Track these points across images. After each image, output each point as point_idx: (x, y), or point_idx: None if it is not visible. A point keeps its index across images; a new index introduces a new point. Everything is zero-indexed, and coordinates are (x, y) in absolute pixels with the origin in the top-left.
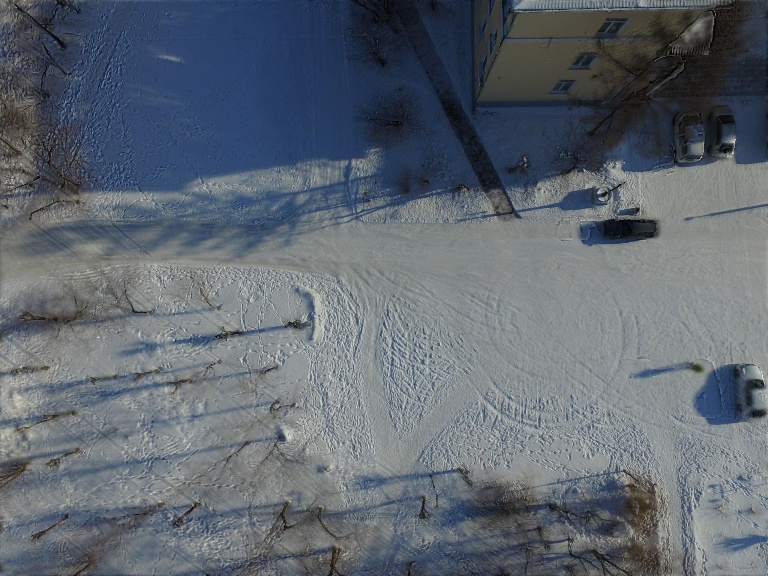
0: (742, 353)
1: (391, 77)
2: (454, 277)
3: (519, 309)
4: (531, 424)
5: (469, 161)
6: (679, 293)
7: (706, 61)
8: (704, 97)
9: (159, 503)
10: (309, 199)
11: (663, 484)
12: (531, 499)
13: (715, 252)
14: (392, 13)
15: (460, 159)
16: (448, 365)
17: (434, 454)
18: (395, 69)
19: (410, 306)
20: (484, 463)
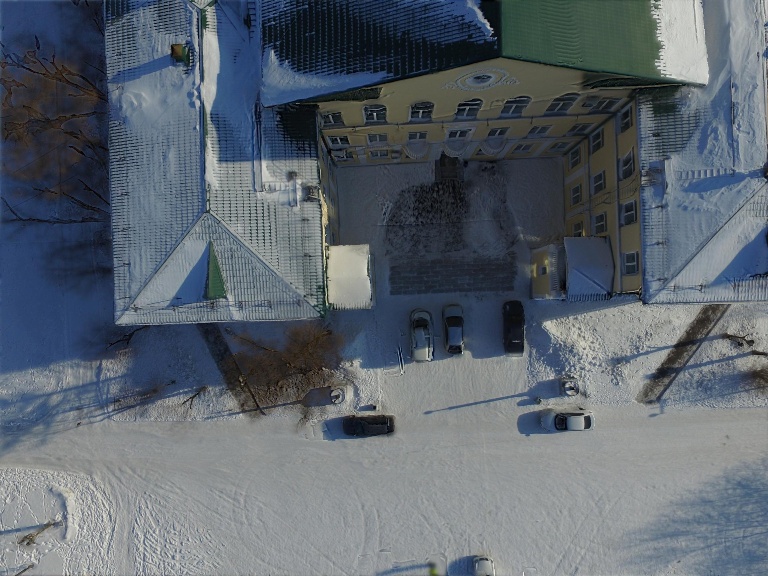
0: (480, 545)
1: None
2: (203, 473)
3: (265, 504)
4: None
5: (214, 360)
6: (419, 486)
7: (435, 263)
8: (439, 294)
9: None
10: (63, 400)
11: None
12: None
13: (454, 445)
14: None
15: (205, 359)
16: (197, 560)
17: None
18: None
19: (161, 503)
20: None
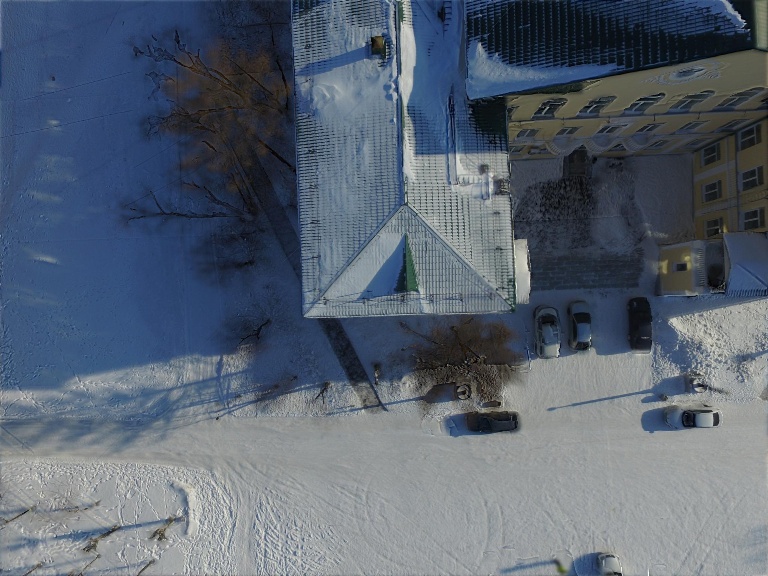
0: (604, 542)
1: (259, 275)
2: (324, 469)
3: (387, 500)
4: None
5: (336, 356)
6: (542, 483)
7: (562, 259)
8: (564, 290)
9: None
10: (183, 395)
11: None
12: None
13: (577, 442)
14: (258, 213)
15: (327, 355)
16: (319, 556)
17: None
18: (262, 268)
19: (282, 498)
20: None
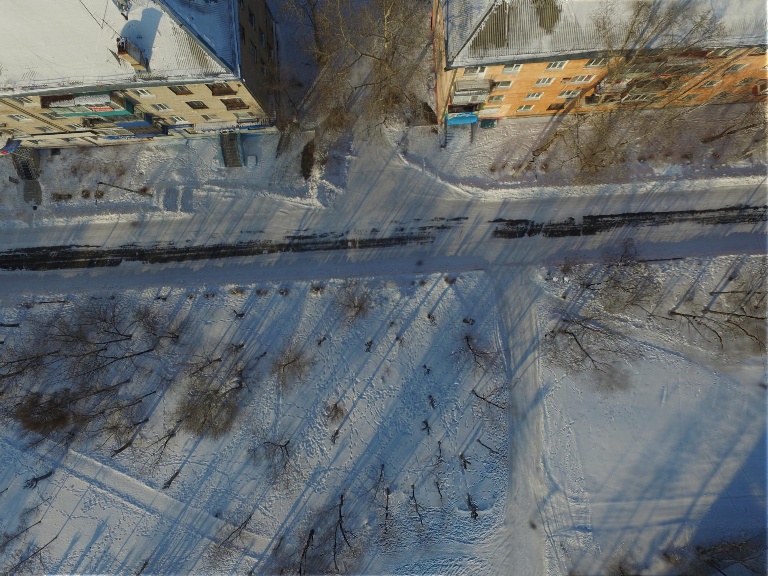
0: None
1: (655, 560)
2: None
3: None
4: None
5: None
6: None
7: None
8: None
9: (337, 405)
10: (561, 501)
11: None
12: None
13: None
14: None
15: None
16: None
17: None
18: (662, 564)
19: None
20: None
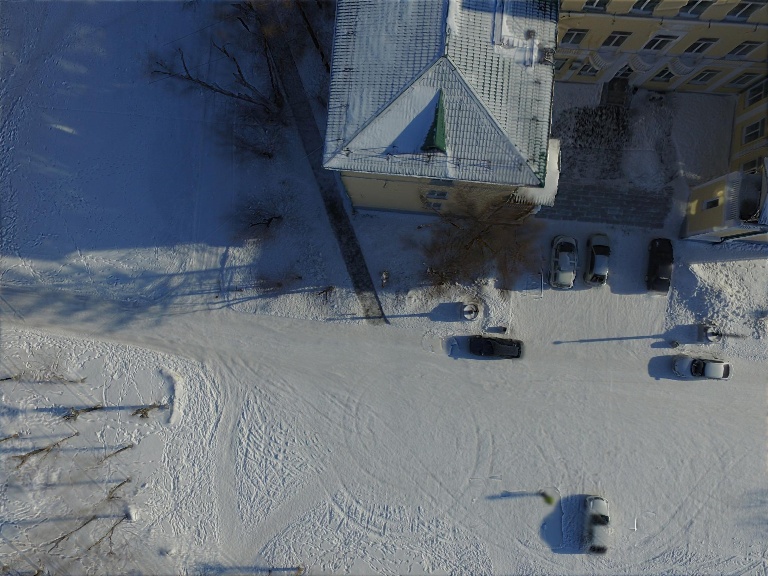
0: (594, 484)
1: (276, 169)
2: (317, 375)
3: (377, 414)
4: (376, 531)
5: (344, 261)
6: (538, 417)
7: (588, 188)
8: (586, 222)
9: (4, 566)
10: (183, 282)
11: None
12: None
13: (580, 379)
14: (283, 106)
15: (335, 259)
16: (301, 462)
17: (277, 550)
18: (280, 162)
19: (270, 399)
20: (324, 565)
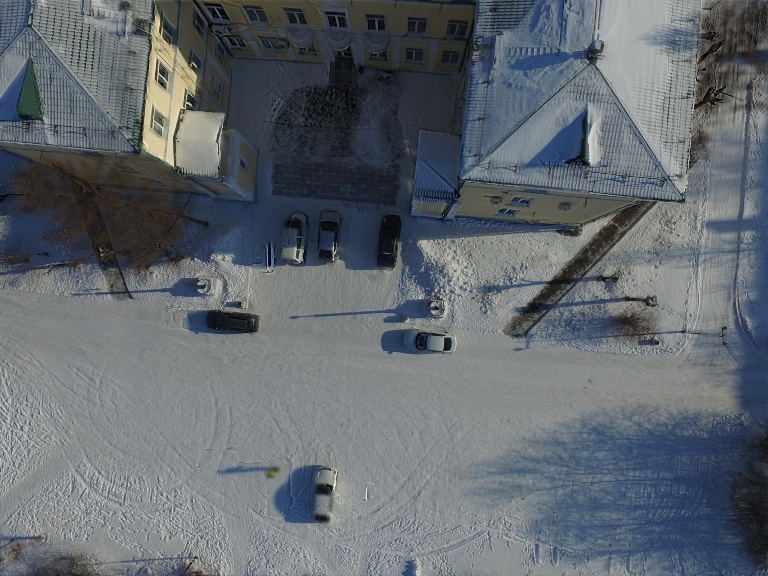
0: (327, 455)
1: None
2: (63, 349)
3: (120, 387)
4: (116, 501)
5: (89, 238)
6: (275, 389)
7: (318, 166)
8: (321, 199)
9: None
10: None
11: (231, 575)
12: (104, 574)
13: (315, 353)
14: None
15: (80, 235)
16: (46, 434)
17: (20, 519)
18: None
19: (17, 373)
20: (65, 534)
